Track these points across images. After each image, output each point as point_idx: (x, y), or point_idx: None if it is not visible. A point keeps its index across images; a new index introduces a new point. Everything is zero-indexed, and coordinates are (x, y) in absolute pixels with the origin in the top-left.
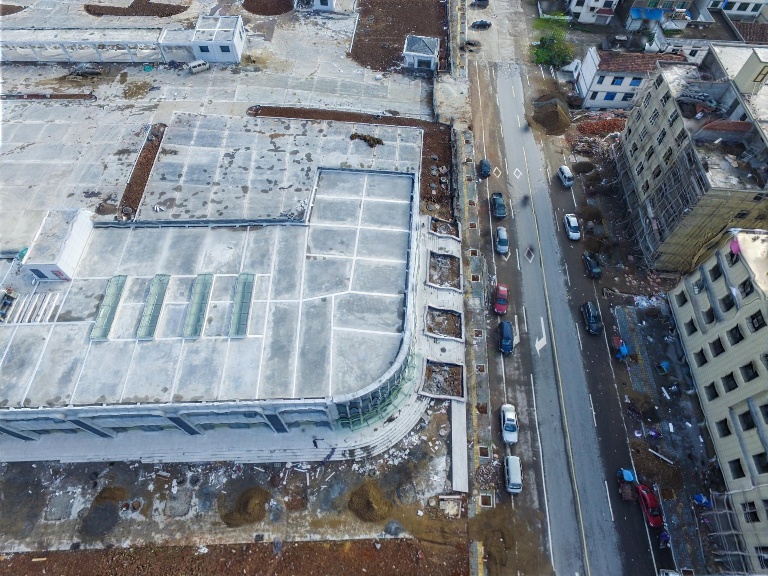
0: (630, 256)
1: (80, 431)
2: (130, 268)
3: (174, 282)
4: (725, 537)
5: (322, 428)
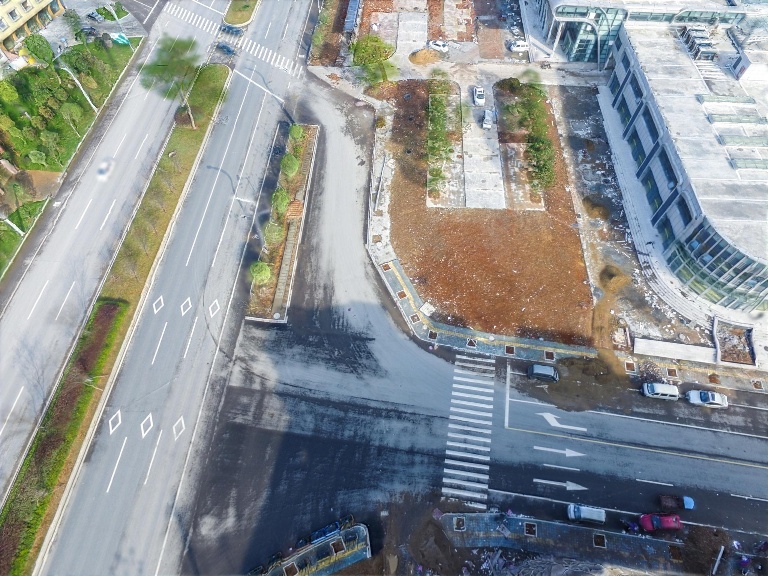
0: None
1: (624, 124)
2: (763, 105)
3: (763, 128)
4: None
5: (662, 247)
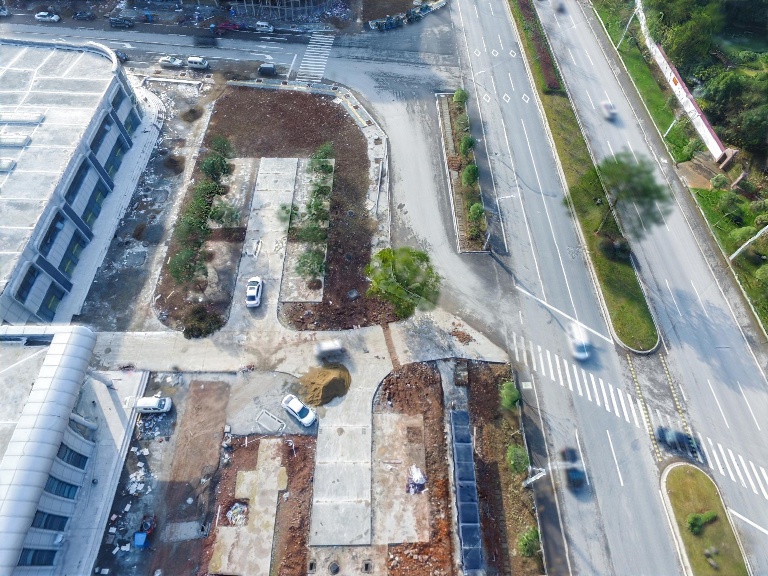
0: (87, 2)
1: (78, 257)
2: None
3: None
4: (247, 4)
5: (137, 129)
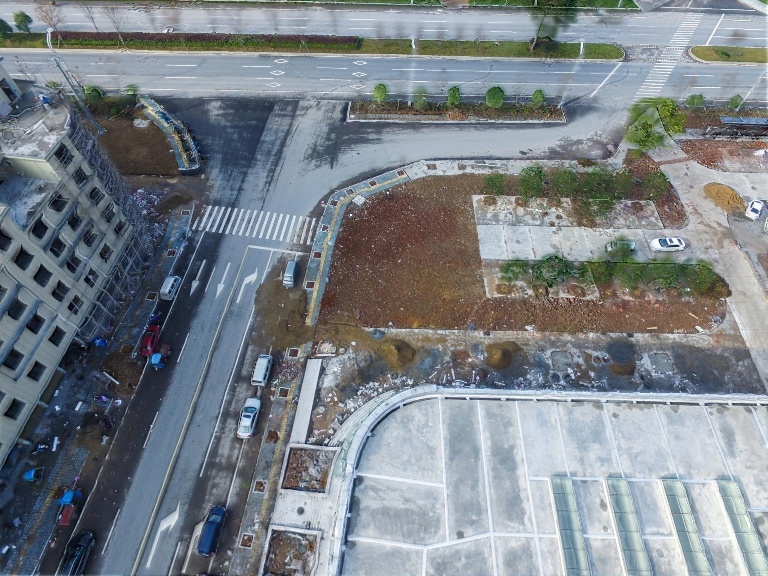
0: None
1: None
2: None
3: None
4: (106, 307)
5: None
